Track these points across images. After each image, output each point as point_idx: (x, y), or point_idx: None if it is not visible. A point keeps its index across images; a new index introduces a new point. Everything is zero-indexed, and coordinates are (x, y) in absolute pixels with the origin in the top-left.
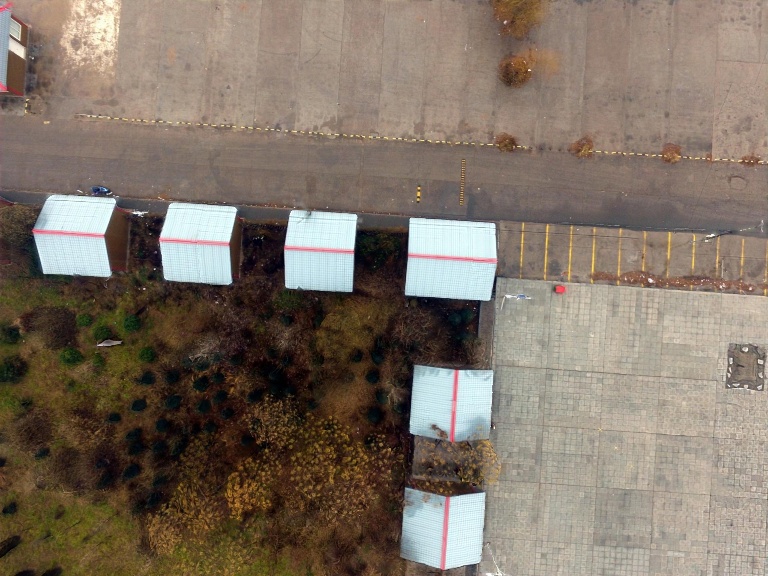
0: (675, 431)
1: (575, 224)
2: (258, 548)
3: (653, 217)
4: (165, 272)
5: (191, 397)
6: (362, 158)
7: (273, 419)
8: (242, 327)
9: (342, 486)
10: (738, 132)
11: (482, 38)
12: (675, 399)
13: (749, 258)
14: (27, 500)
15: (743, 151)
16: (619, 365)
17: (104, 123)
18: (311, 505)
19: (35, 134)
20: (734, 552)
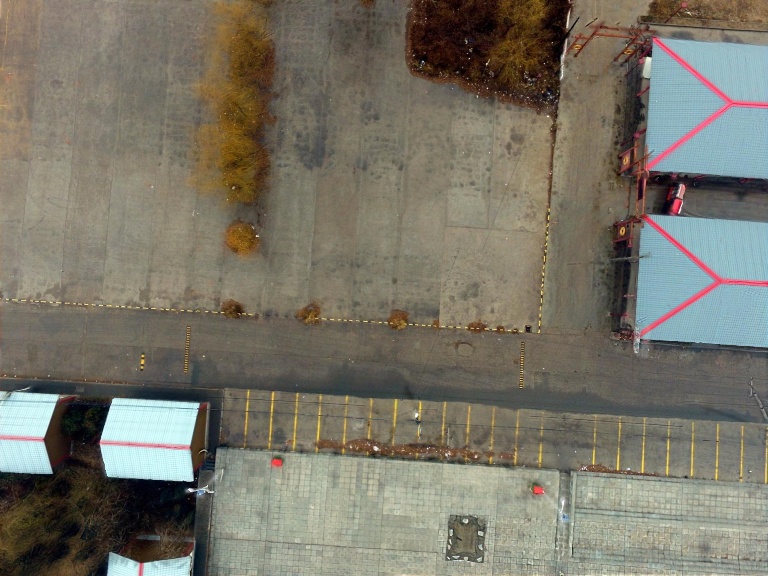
0: None
1: (301, 391)
2: None
3: (380, 384)
4: None
5: None
6: (85, 326)
7: None
8: None
9: None
10: (465, 298)
11: (210, 204)
12: (395, 571)
13: (475, 426)
14: None
15: (470, 318)
16: (339, 537)
17: None
18: None
19: None
20: None
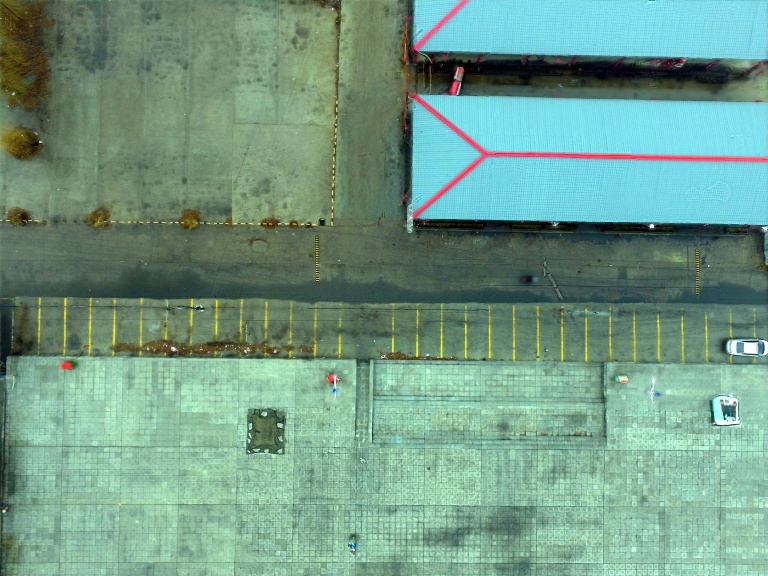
0: (197, 500)
1: (94, 296)
2: None
3: (174, 285)
4: None
5: None
6: None
7: None
8: None
9: None
10: (257, 195)
11: None
12: (196, 468)
13: (273, 321)
14: None
15: (263, 214)
16: (137, 438)
17: None
18: None
19: None
20: None
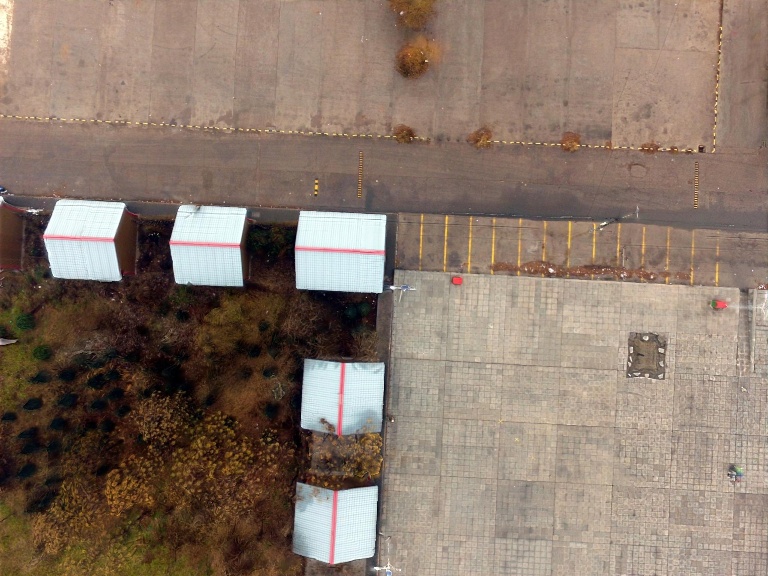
0: (576, 421)
1: (474, 215)
2: (157, 546)
3: (553, 206)
4: (52, 269)
5: (88, 395)
6: (259, 152)
7: (156, 415)
8: (139, 324)
9: (223, 481)
10: (637, 119)
11: (378, 29)
12: (576, 389)
13: (650, 246)
14: None
15: (643, 138)
16: (519, 356)
17: None
18: None
19: None
20: (637, 542)
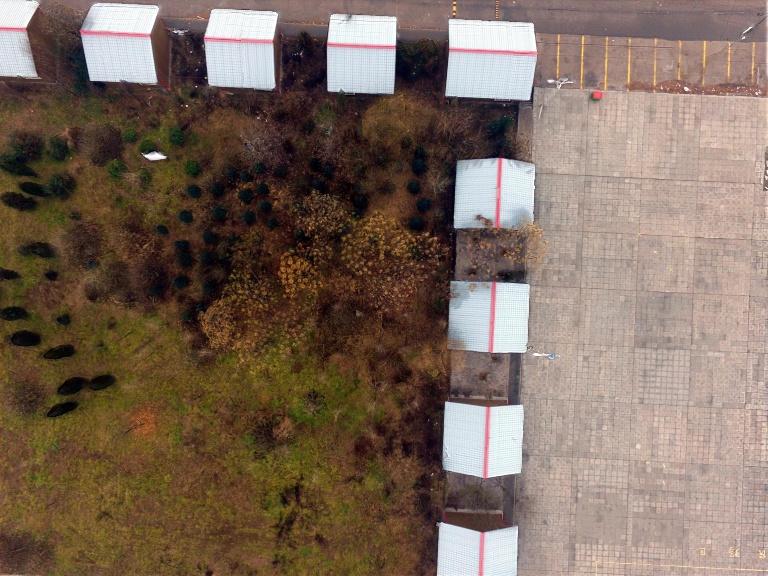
0: (713, 234)
1: (610, 35)
2: (305, 356)
3: (688, 26)
4: (210, 75)
5: (236, 211)
6: None
7: (322, 205)
8: (284, 142)
9: (392, 264)
10: None
11: None
12: (713, 203)
13: None
14: (79, 312)
15: None
16: (657, 170)
17: None
18: None
19: None
20: None
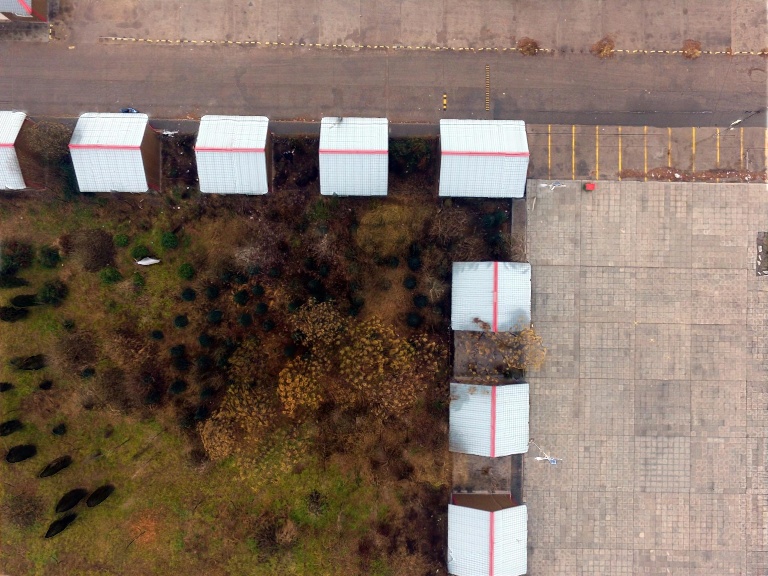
0: (709, 320)
1: (600, 124)
2: None
3: (677, 113)
4: (201, 183)
5: (231, 312)
6: (387, 69)
7: (319, 317)
8: (278, 241)
9: (391, 376)
10: (756, 25)
11: None
12: (707, 289)
13: None
14: (75, 421)
15: (762, 43)
16: (651, 259)
17: (129, 45)
18: (356, 412)
19: (61, 60)
20: None
